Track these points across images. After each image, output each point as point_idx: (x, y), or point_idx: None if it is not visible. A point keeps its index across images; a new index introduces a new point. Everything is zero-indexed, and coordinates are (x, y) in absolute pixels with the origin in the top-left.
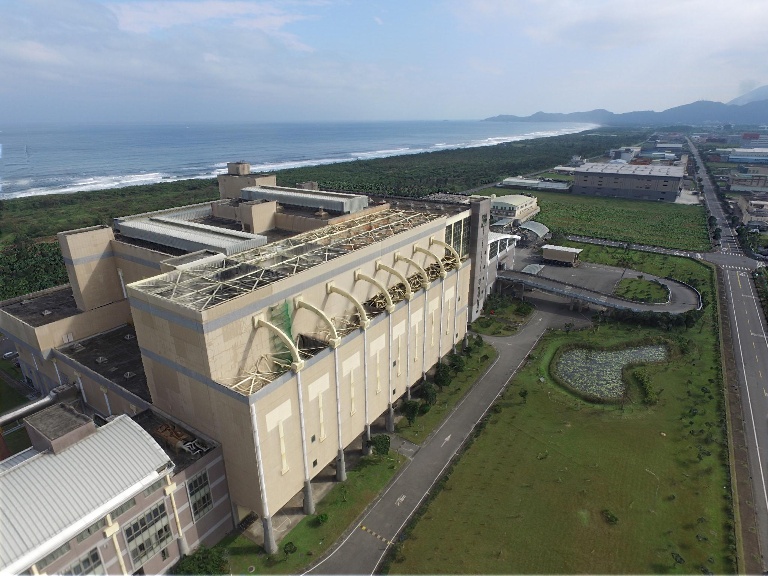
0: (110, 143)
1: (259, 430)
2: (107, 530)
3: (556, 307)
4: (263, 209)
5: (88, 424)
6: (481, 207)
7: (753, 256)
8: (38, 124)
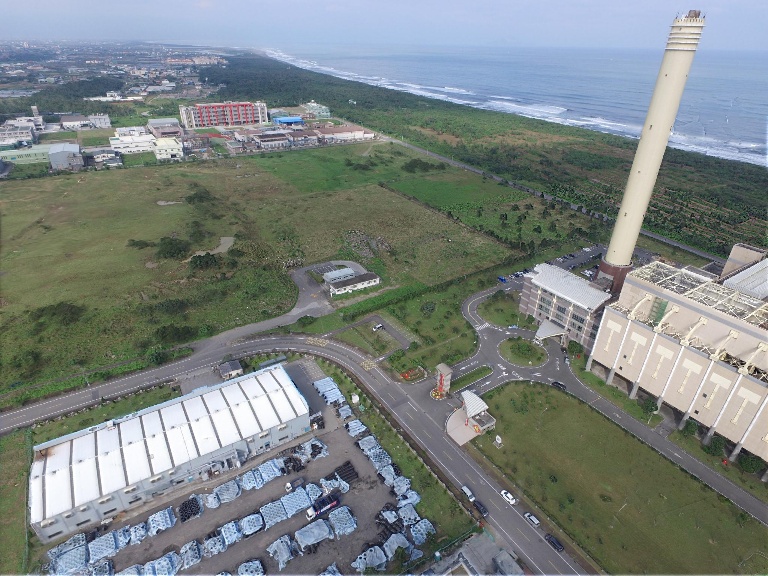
0: None
1: (604, 321)
2: (570, 307)
3: None
4: None
5: (601, 287)
6: None
7: None
8: None
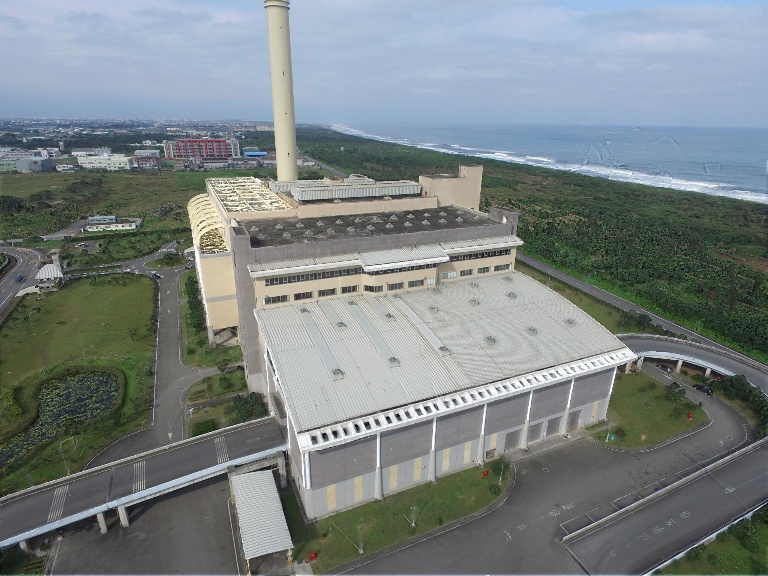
0: None
1: None
2: None
3: None
4: None
5: None
6: None
7: None
8: None
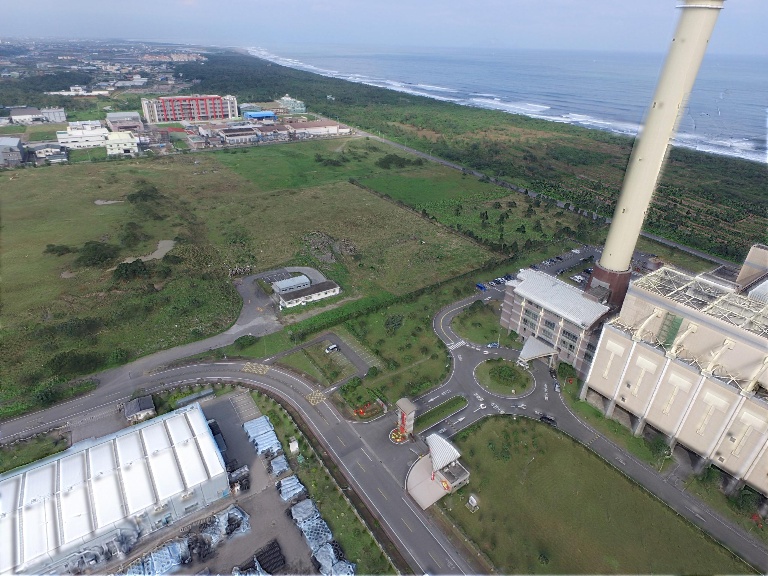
0: None
1: (602, 342)
2: (560, 322)
3: None
4: None
5: (597, 298)
6: None
7: None
8: None
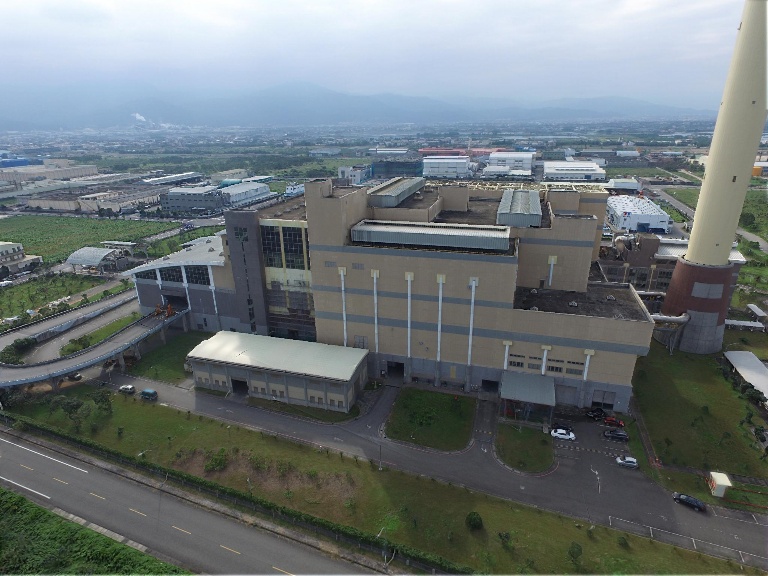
0: None
1: None
2: None
3: None
4: None
5: None
6: None
7: (200, 218)
8: None
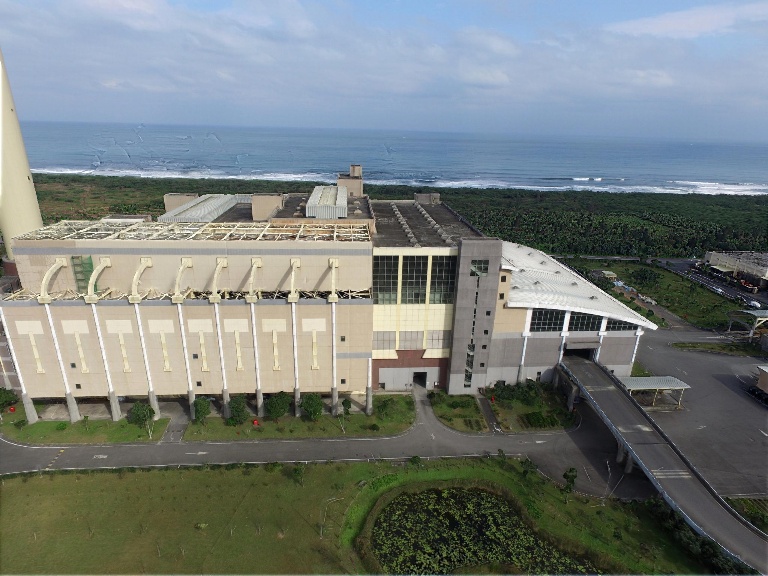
0: (452, 149)
1: (10, 328)
2: None
3: (603, 445)
4: (265, 201)
5: None
6: (467, 248)
7: None
8: (389, 130)
